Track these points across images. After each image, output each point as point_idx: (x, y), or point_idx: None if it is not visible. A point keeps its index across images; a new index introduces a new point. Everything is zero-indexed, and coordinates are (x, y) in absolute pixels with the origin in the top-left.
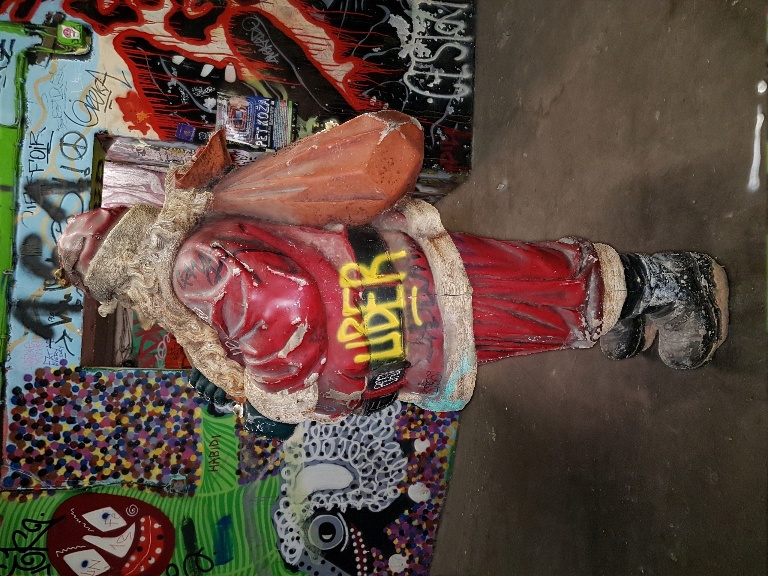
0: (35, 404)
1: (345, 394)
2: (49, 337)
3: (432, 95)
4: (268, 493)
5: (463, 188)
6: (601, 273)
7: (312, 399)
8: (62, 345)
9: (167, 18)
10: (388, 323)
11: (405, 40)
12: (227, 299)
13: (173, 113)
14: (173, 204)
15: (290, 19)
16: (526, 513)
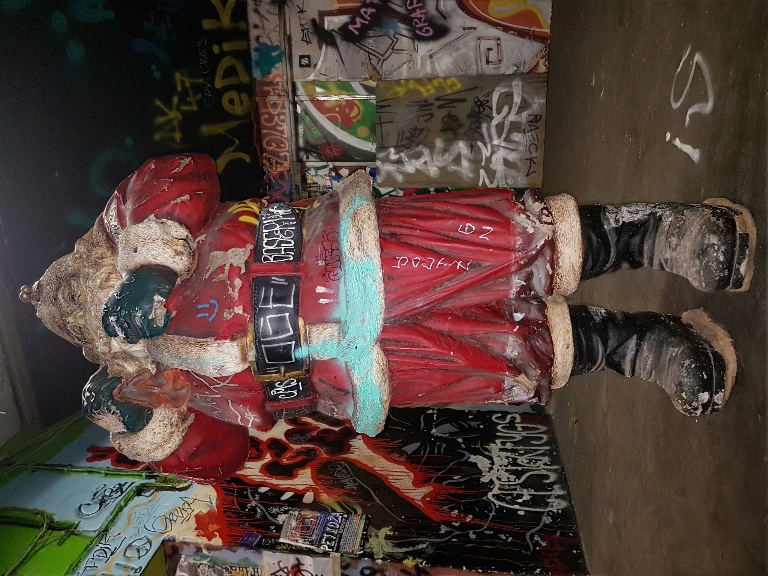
0: None
1: (224, 256)
2: None
3: (523, 508)
4: None
5: None
6: None
7: (178, 227)
8: None
9: (264, 466)
10: None
11: (487, 470)
12: None
13: (244, 524)
14: None
15: (373, 462)
16: None
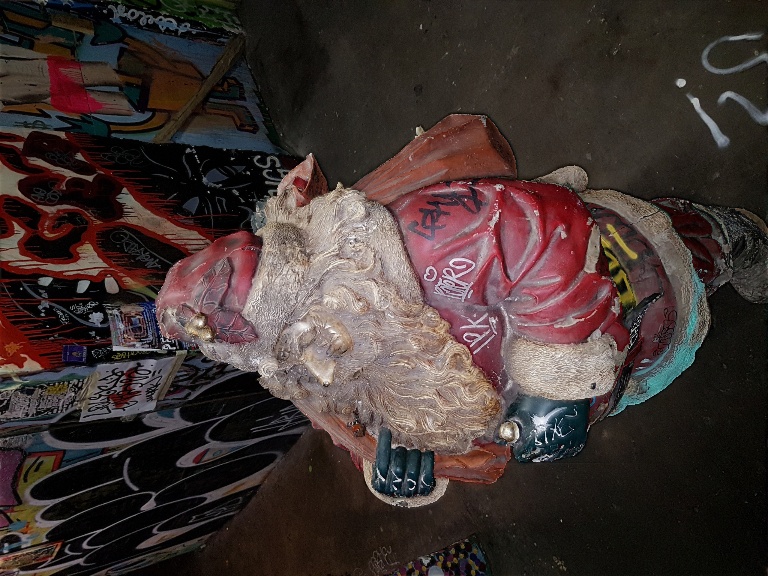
0: None
1: None
2: None
3: None
4: None
5: None
6: None
7: None
8: None
9: (21, 243)
10: (612, 261)
11: None
12: (504, 219)
13: (53, 336)
14: None
15: (160, 227)
16: None
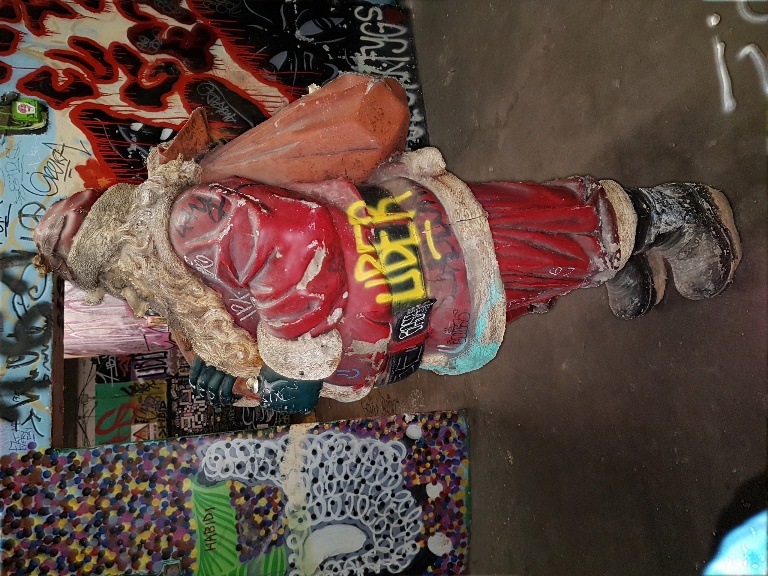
0: (1, 497)
1: (370, 344)
2: (14, 419)
3: None
4: (275, 567)
5: None
6: None
7: (337, 344)
8: (30, 426)
9: (122, 90)
10: (405, 260)
11: None
12: (234, 232)
13: (135, 176)
14: (161, 166)
15: (243, 82)
16: (564, 526)
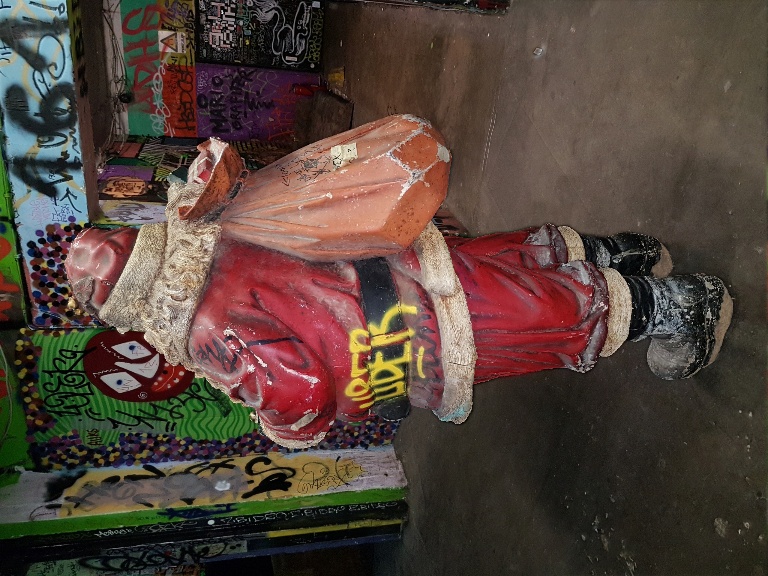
0: (51, 256)
1: None
2: (53, 195)
3: None
4: None
5: (497, 22)
6: (608, 317)
7: (320, 439)
8: (67, 203)
9: None
10: (393, 376)
11: None
12: (243, 387)
13: None
14: (181, 261)
15: None
16: (503, 391)
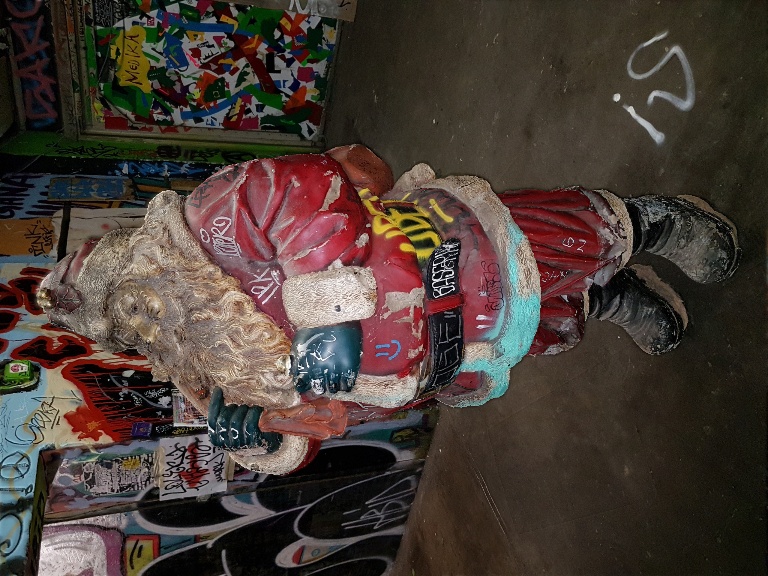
0: None
1: (404, 296)
2: None
3: None
4: None
5: (439, 430)
6: None
7: (370, 276)
8: None
9: None
10: (420, 224)
11: None
12: (250, 181)
13: (127, 416)
14: None
15: None
16: None
